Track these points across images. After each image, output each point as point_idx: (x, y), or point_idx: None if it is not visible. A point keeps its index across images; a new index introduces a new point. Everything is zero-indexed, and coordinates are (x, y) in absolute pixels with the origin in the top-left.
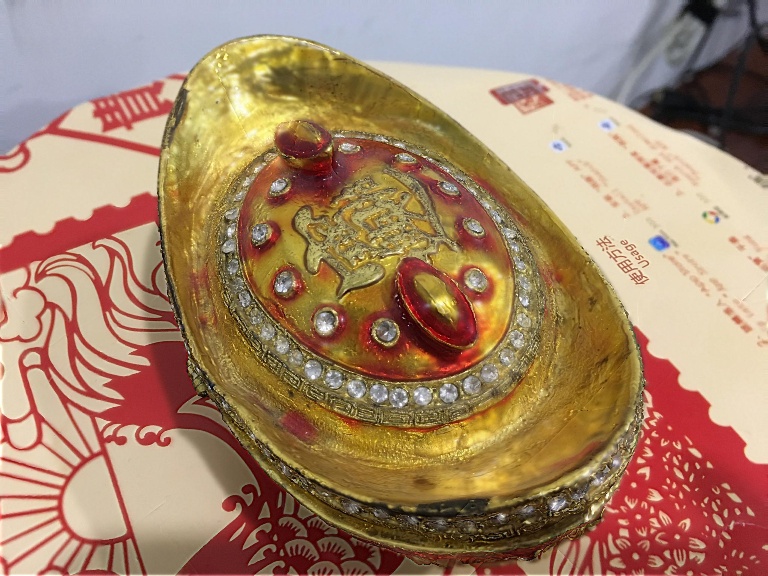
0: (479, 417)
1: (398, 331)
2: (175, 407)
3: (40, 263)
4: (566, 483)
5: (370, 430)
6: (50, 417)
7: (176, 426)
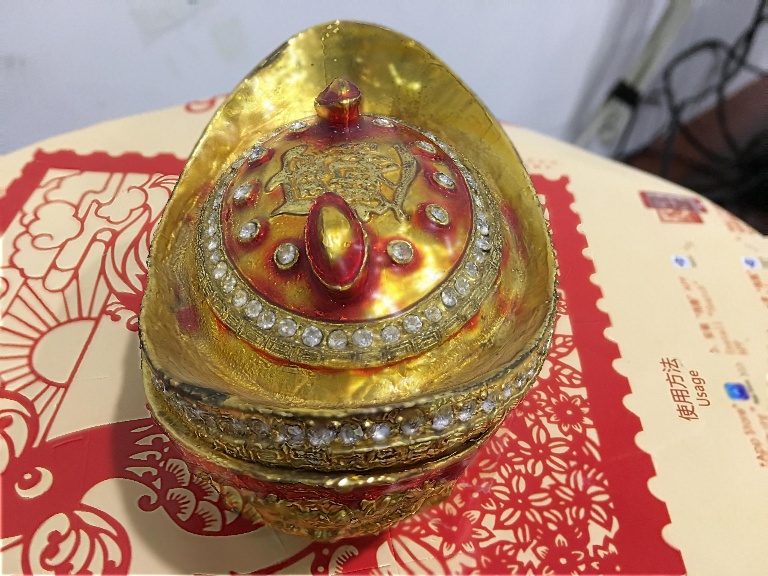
0: (330, 374)
1: (296, 259)
2: None
3: (162, 176)
4: (300, 413)
5: (231, 340)
6: (83, 278)
7: None
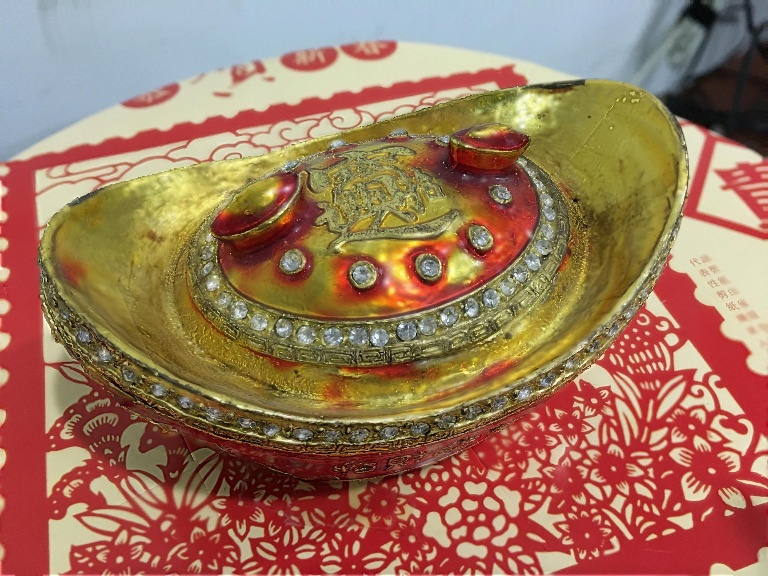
0: None
1: None
2: None
3: None
4: None
5: None
6: None
7: None
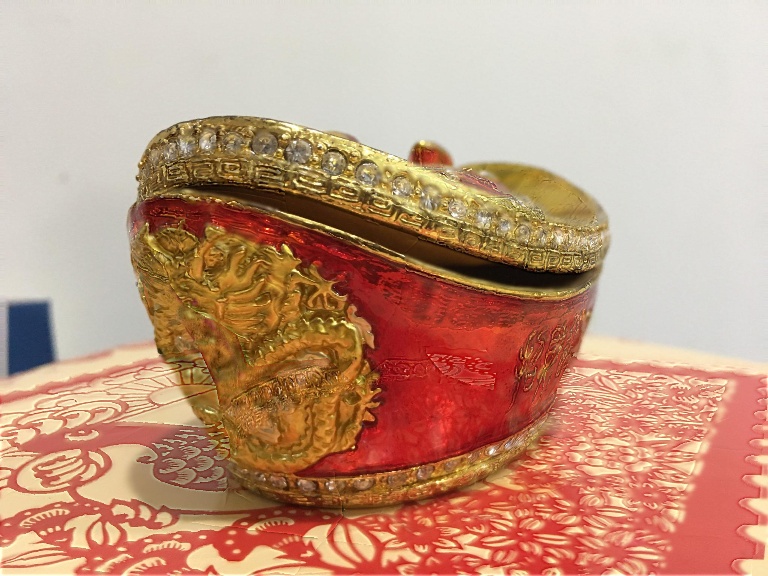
0: None
1: None
2: None
3: None
4: None
5: None
6: None
7: None
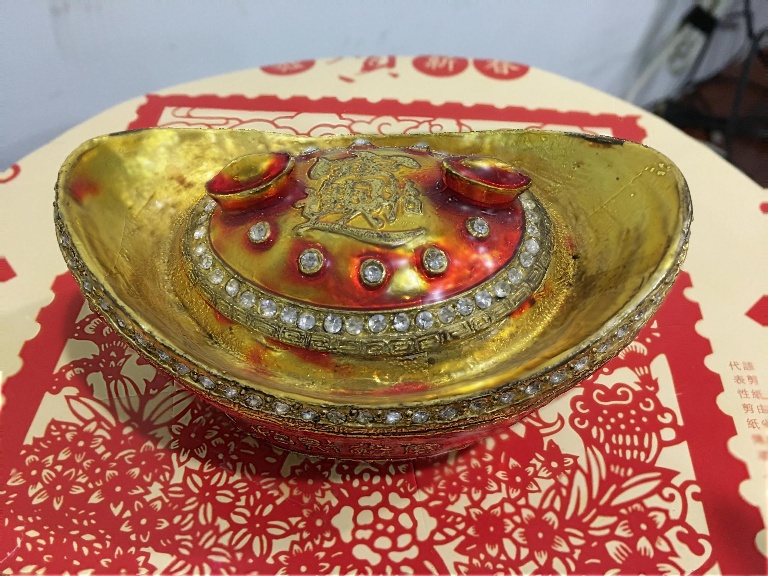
0: None
1: None
2: None
3: None
4: (70, 154)
5: None
6: None
7: None
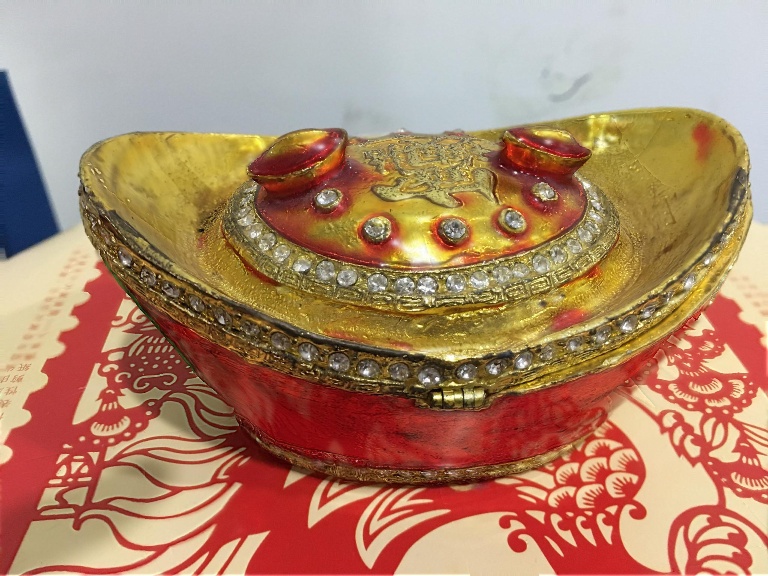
0: None
1: (549, 186)
2: (360, 570)
3: None
4: None
5: (606, 265)
6: None
7: (389, 575)
